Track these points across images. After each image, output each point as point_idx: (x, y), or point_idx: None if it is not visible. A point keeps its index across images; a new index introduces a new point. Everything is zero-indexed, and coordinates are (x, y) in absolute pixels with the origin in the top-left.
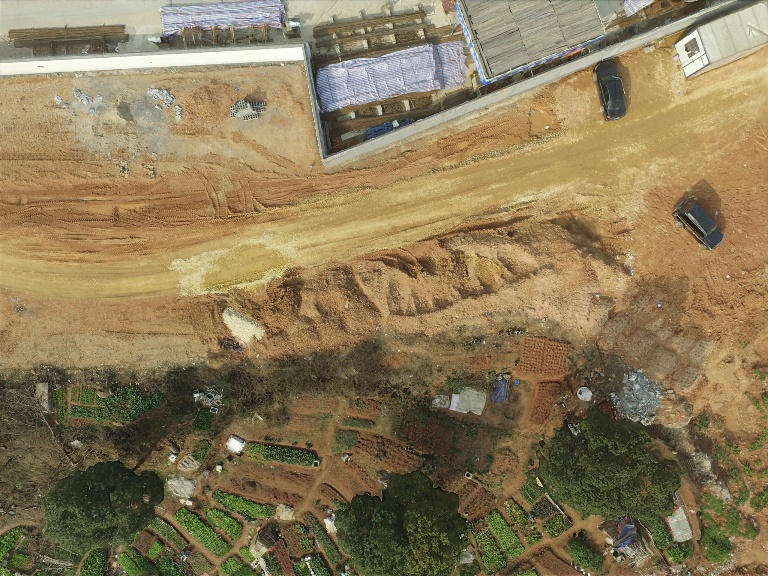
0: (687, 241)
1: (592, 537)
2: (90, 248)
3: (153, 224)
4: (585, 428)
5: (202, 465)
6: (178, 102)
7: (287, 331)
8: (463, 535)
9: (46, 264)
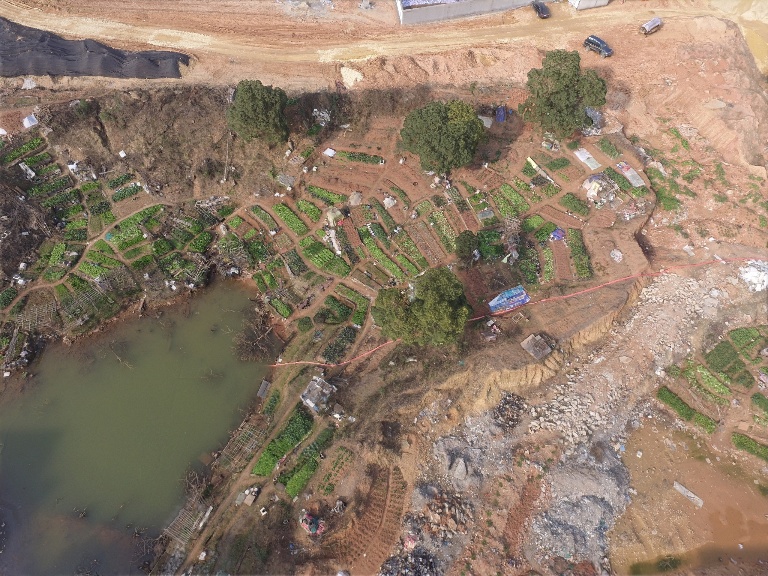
0: (594, 56)
1: (577, 196)
2: (277, 44)
3: (312, 38)
4: (544, 60)
5: (305, 163)
6: (334, 4)
7: (376, 76)
8: (484, 200)
9: (252, 48)
